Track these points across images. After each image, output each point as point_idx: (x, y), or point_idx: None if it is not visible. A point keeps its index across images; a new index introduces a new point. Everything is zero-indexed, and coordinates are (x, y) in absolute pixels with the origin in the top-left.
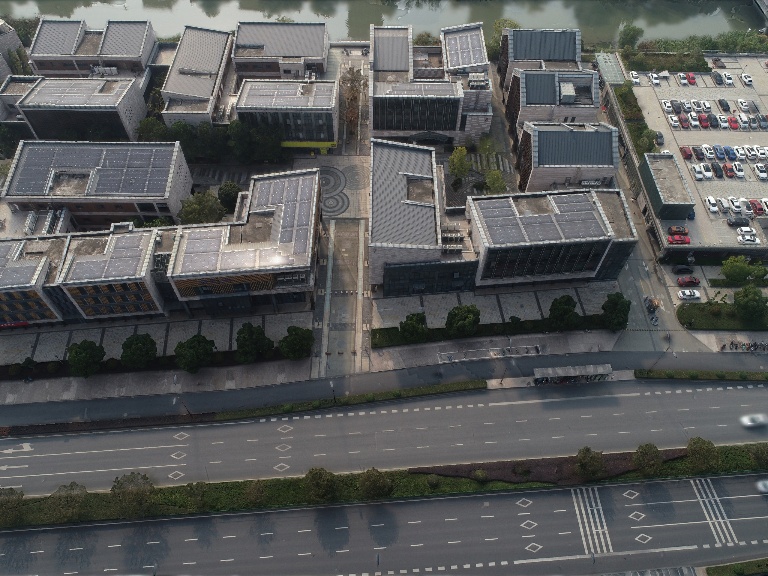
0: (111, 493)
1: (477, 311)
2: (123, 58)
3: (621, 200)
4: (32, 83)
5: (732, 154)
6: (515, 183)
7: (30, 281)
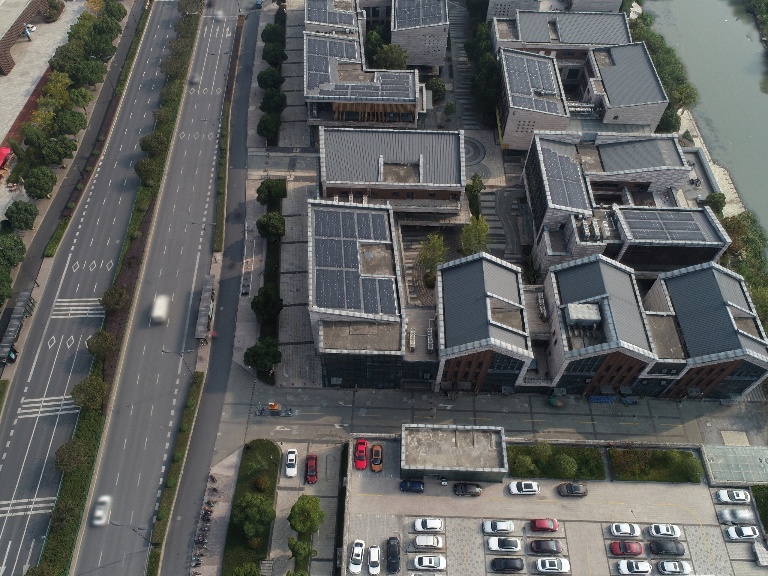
0: (175, 54)
1: (271, 226)
2: None
3: None
4: None
5: None
6: None
7: None
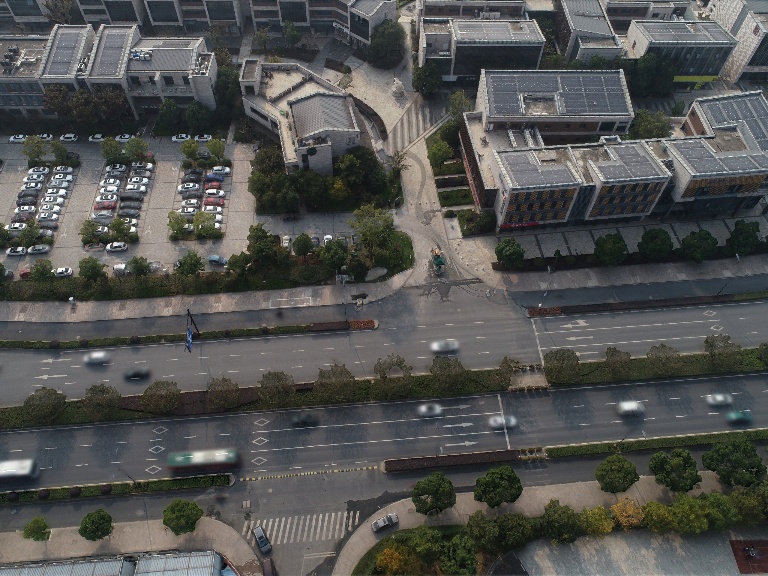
0: (708, 349)
1: None
2: (508, 3)
3: None
4: (443, 24)
5: None
6: None
7: (573, 180)
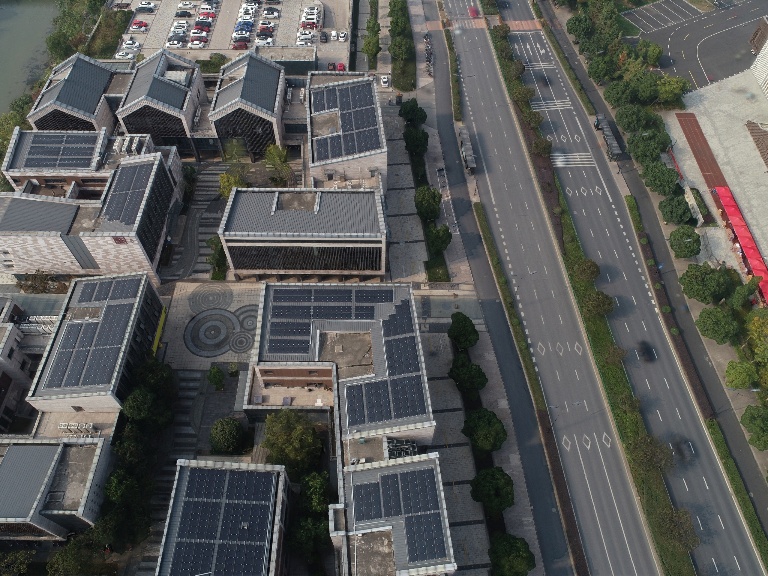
0: None
1: None
2: None
3: (320, 75)
4: None
5: (249, 23)
6: (246, 164)
7: None
